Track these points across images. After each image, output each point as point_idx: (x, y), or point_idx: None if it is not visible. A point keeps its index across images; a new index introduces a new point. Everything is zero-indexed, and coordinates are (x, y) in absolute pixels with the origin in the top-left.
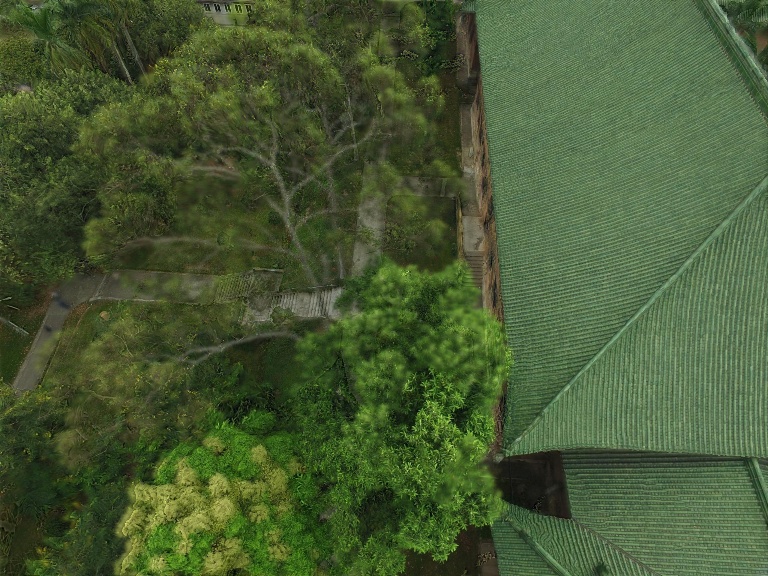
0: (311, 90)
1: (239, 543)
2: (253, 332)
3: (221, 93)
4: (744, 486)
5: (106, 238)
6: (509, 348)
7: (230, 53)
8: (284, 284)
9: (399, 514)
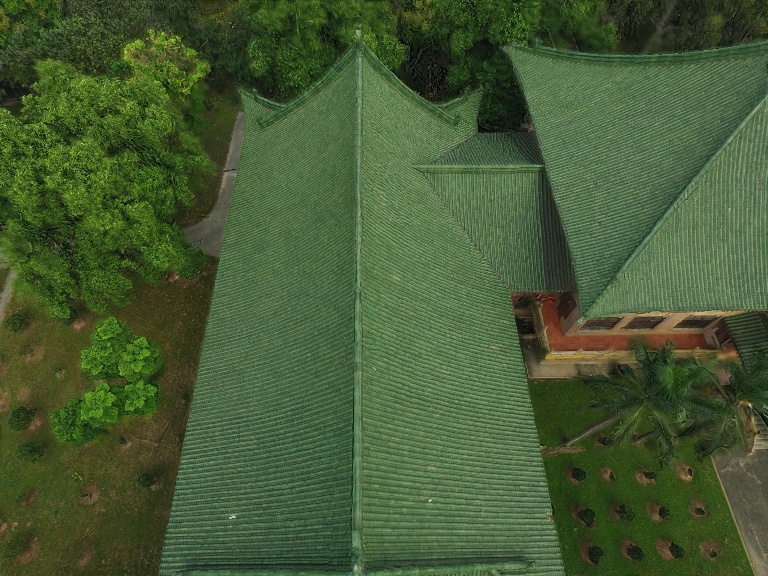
0: None
1: None
2: None
3: None
4: None
5: None
6: None
7: None
8: None
9: None
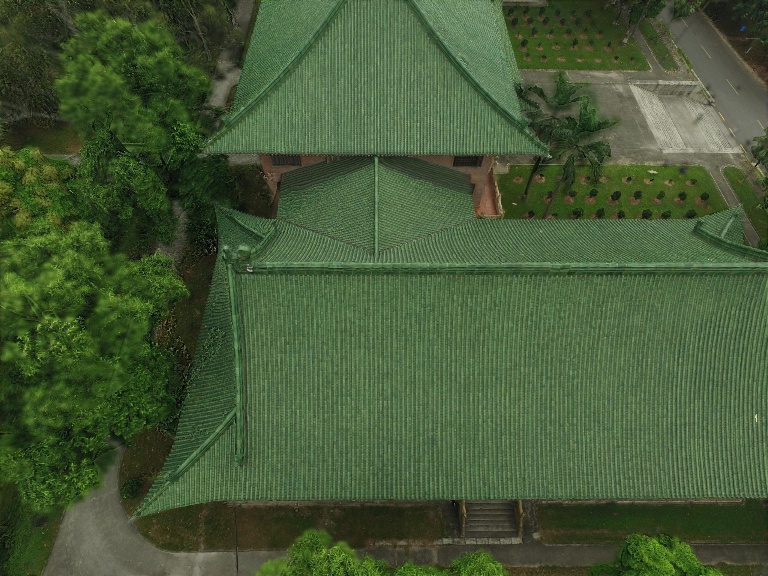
0: (174, 7)
1: (7, 184)
2: None
3: None
4: None
5: None
6: (232, 110)
7: None
8: None
9: (111, 165)
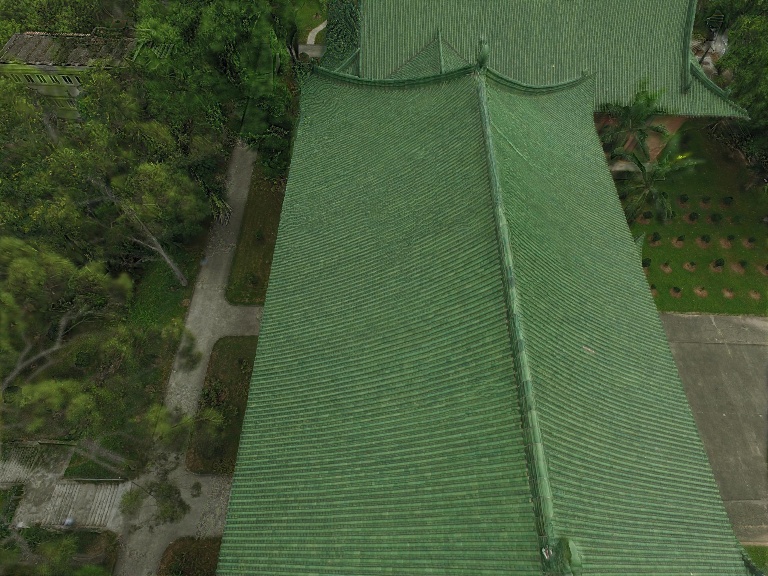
0: None
1: None
2: None
3: None
4: None
5: None
6: None
7: (24, 155)
8: (72, 466)
9: None
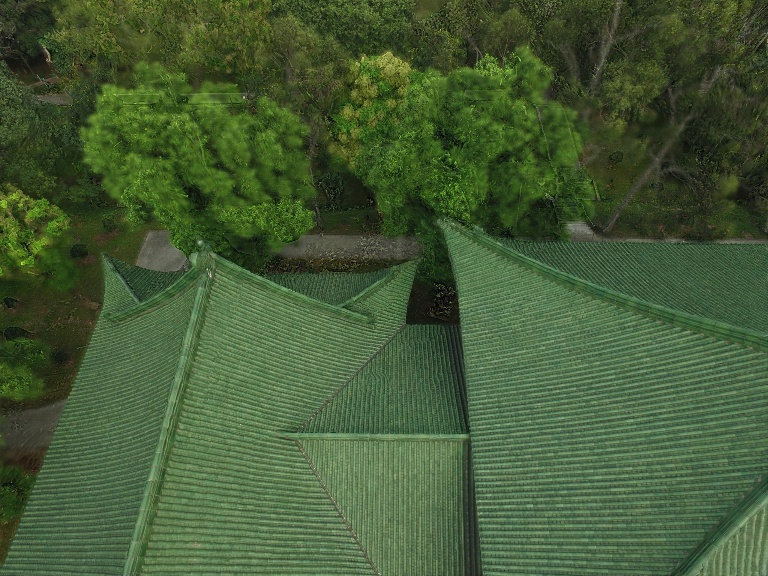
0: None
1: (375, 90)
2: (534, 190)
3: (765, 76)
4: (443, 431)
5: (580, 75)
6: None
7: None
8: None
9: None
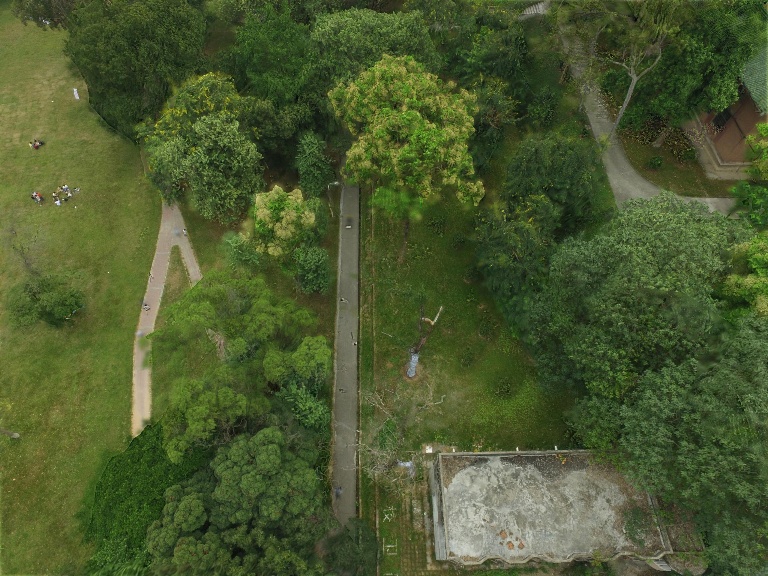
0: None
1: None
2: None
3: None
4: None
5: None
6: None
7: None
8: None
9: None
